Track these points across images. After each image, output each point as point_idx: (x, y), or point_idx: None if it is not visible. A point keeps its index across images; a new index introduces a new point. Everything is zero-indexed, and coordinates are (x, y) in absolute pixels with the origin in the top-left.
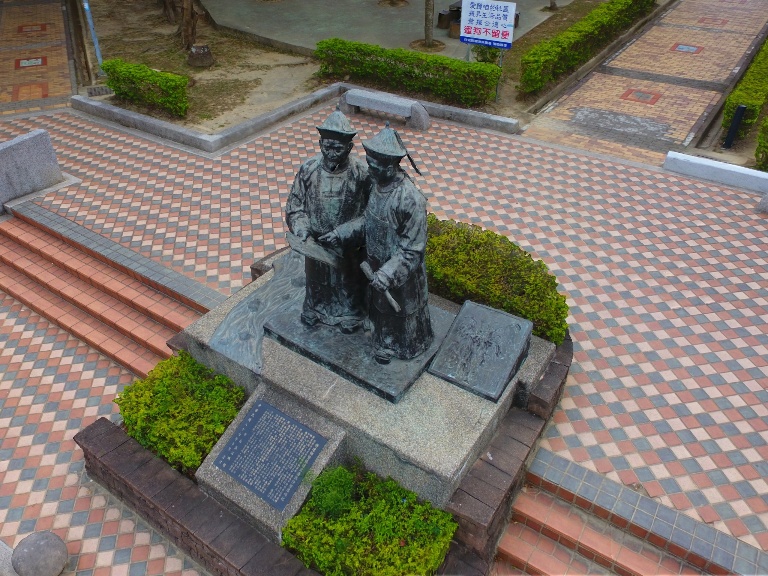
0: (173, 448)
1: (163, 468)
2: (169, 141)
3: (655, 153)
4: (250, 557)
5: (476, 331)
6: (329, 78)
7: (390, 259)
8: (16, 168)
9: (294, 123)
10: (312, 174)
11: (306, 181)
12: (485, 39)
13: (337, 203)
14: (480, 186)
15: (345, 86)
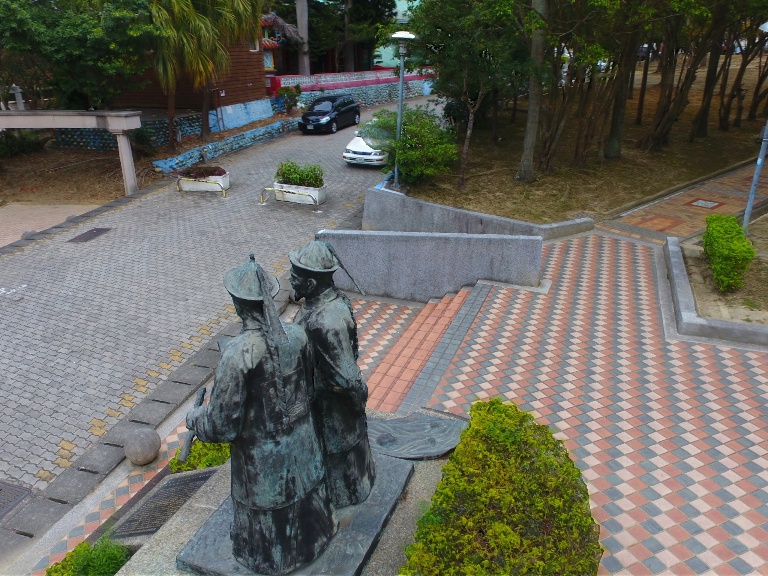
0: None
1: None
2: (670, 305)
3: None
4: None
5: None
6: None
7: None
8: (502, 257)
9: None
10: None
11: None
12: None
13: None
14: None
15: None
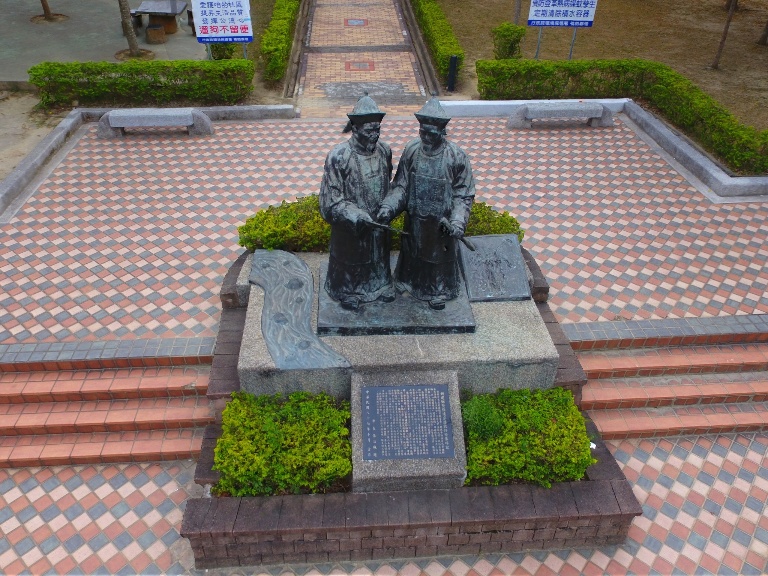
0: (322, 468)
1: (303, 500)
2: None
3: (412, 106)
4: (449, 509)
5: (484, 257)
6: (54, 108)
7: (455, 210)
8: None
9: (64, 161)
10: (349, 162)
11: (344, 170)
12: (224, 36)
13: (379, 181)
14: (314, 167)
15: (87, 111)
